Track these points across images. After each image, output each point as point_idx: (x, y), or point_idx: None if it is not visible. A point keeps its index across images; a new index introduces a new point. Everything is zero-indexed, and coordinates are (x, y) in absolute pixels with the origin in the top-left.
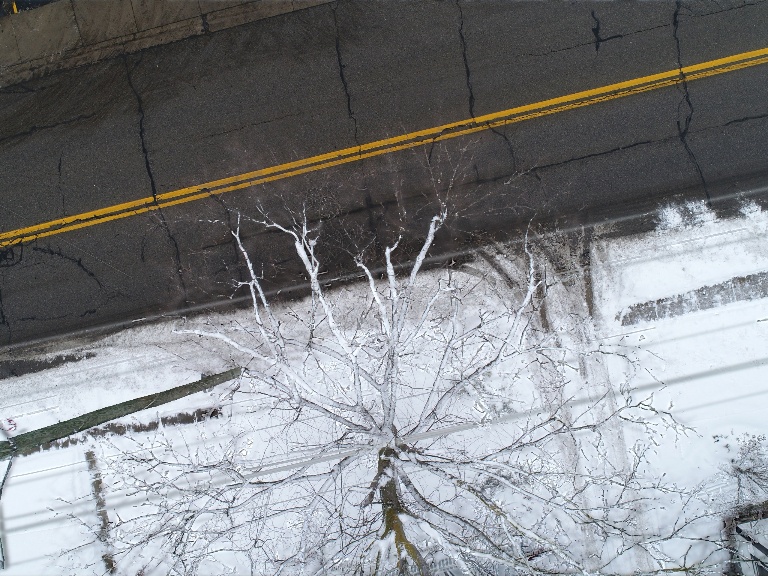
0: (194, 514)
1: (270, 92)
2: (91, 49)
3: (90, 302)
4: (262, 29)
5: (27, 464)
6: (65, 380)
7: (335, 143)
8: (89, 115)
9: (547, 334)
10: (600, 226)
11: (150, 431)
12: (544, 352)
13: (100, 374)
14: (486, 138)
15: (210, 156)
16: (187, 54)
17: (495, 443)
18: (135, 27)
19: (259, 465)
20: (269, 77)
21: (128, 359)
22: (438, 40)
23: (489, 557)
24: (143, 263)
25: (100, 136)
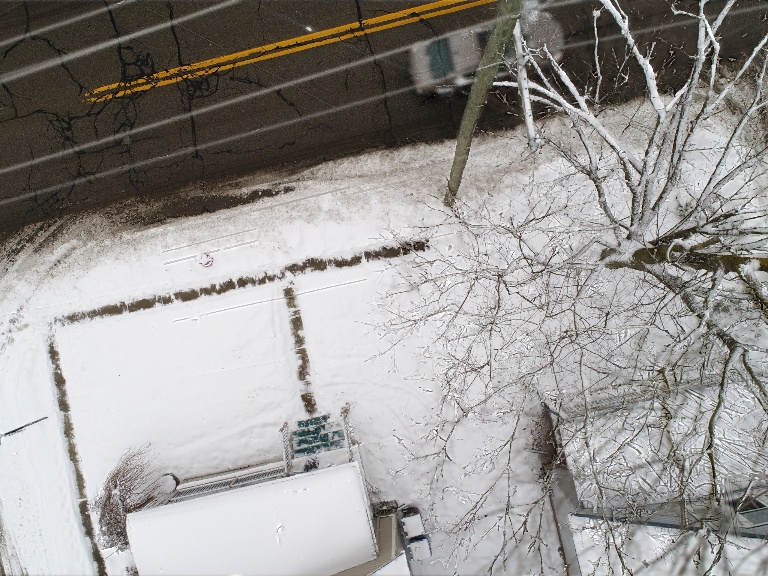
0: (502, 273)
1: None
2: None
3: (289, 134)
4: None
5: (224, 300)
6: (264, 213)
7: None
8: None
9: None
10: None
11: (352, 266)
12: None
13: (302, 206)
14: None
15: None
16: None
17: None
18: None
19: (553, 235)
20: None
21: (331, 191)
22: None
23: None
24: (347, 92)
25: None
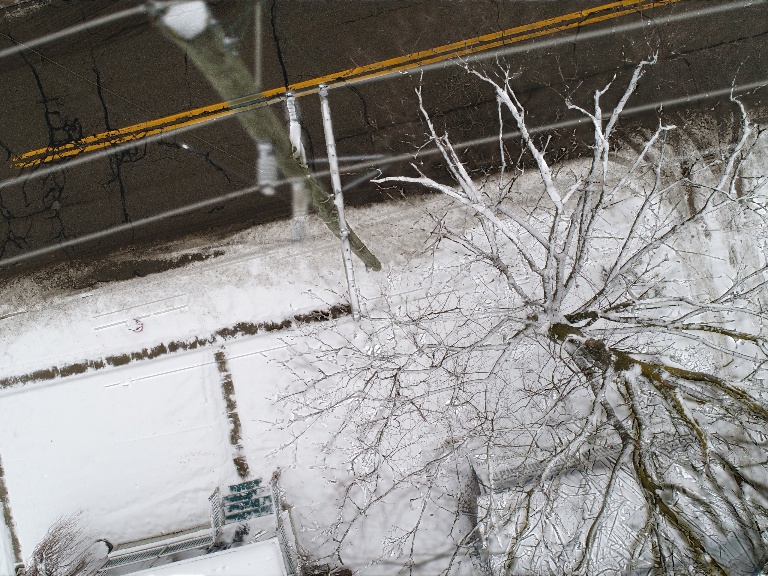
0: (400, 367)
1: None
2: None
3: (218, 198)
4: None
5: (155, 365)
6: (193, 278)
7: (476, 28)
8: (217, 2)
9: (696, 222)
10: (750, 111)
11: None
12: (693, 241)
13: (231, 271)
14: (633, 22)
15: (345, 44)
16: None
17: (707, 293)
18: None
19: (456, 324)
20: None
21: (260, 255)
22: None
23: (742, 385)
24: (274, 156)
25: (228, 24)
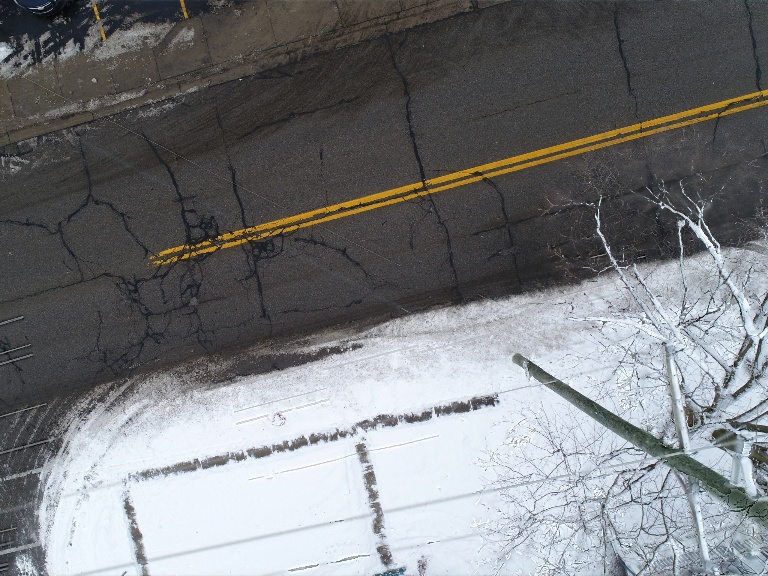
0: (604, 504)
1: (544, 70)
2: (351, 30)
3: (356, 292)
4: (535, 4)
5: (298, 458)
6: (334, 372)
7: (615, 121)
8: (351, 99)
9: None
10: None
11: (423, 421)
12: None
13: (371, 365)
14: None
15: (482, 138)
16: (455, 33)
17: None
18: (399, 6)
19: None
20: (543, 54)
21: (399, 349)
22: (722, 11)
23: None
24: (412, 251)
25: (364, 121)
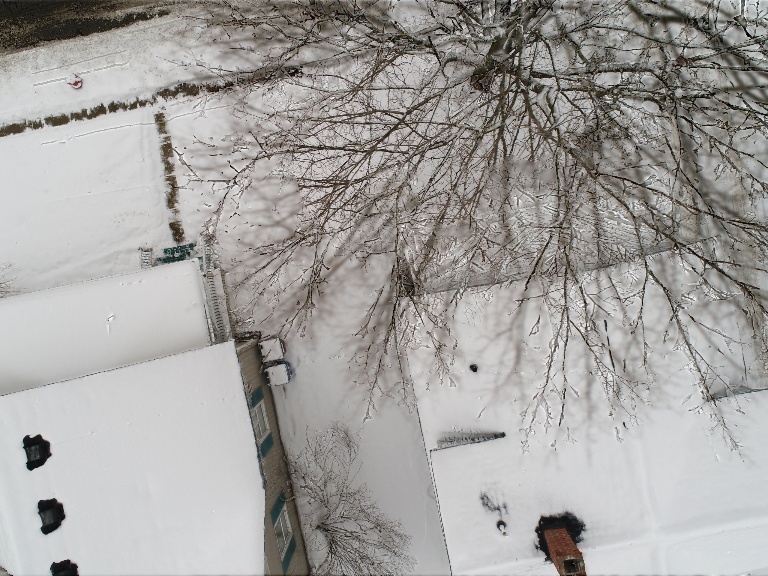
0: None
1: None
2: None
3: None
4: None
5: (93, 123)
6: (136, 35)
7: None
8: None
9: None
10: None
11: None
12: (648, 7)
13: (174, 28)
14: None
15: None
16: None
17: None
18: None
19: None
20: None
21: (204, 13)
22: None
23: None
24: None
25: None
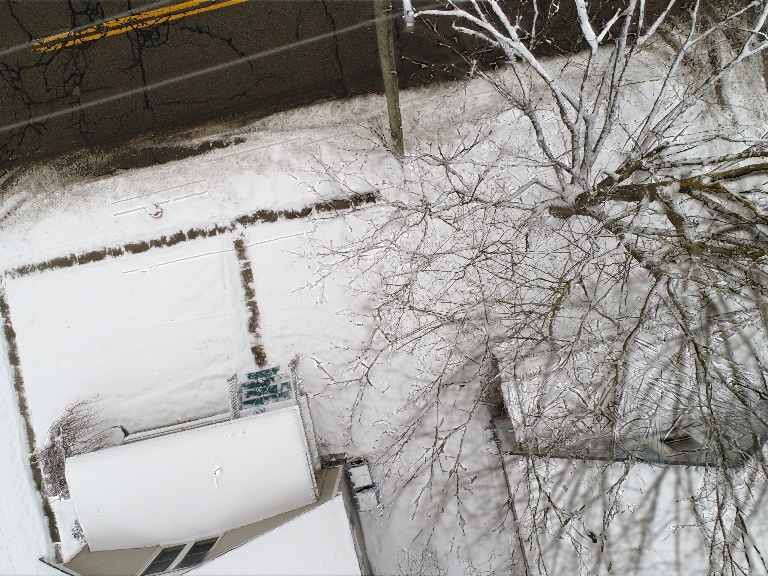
0: (430, 203)
1: None
2: None
3: (240, 84)
4: None
5: (174, 251)
6: (214, 164)
7: None
8: None
9: (723, 111)
10: None
11: (303, 217)
12: None
13: (252, 157)
14: None
15: None
16: None
17: None
18: None
19: (486, 168)
20: None
21: (281, 142)
22: None
23: None
24: (298, 42)
25: None
